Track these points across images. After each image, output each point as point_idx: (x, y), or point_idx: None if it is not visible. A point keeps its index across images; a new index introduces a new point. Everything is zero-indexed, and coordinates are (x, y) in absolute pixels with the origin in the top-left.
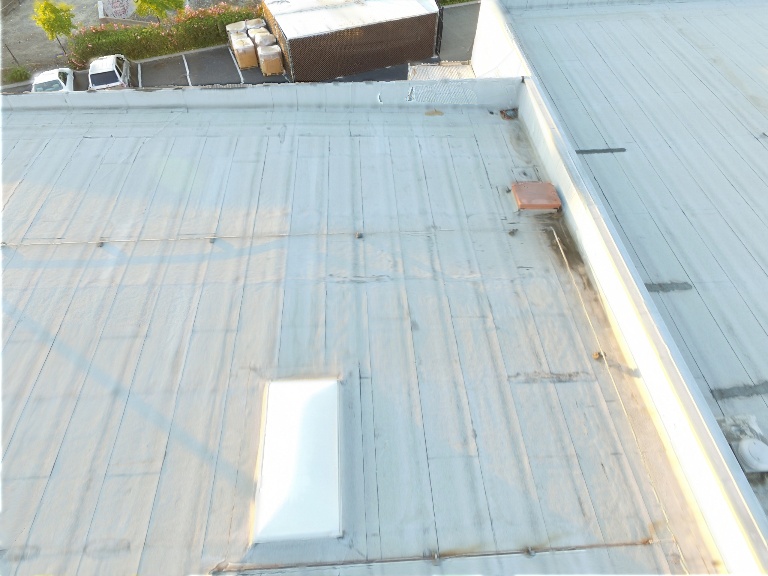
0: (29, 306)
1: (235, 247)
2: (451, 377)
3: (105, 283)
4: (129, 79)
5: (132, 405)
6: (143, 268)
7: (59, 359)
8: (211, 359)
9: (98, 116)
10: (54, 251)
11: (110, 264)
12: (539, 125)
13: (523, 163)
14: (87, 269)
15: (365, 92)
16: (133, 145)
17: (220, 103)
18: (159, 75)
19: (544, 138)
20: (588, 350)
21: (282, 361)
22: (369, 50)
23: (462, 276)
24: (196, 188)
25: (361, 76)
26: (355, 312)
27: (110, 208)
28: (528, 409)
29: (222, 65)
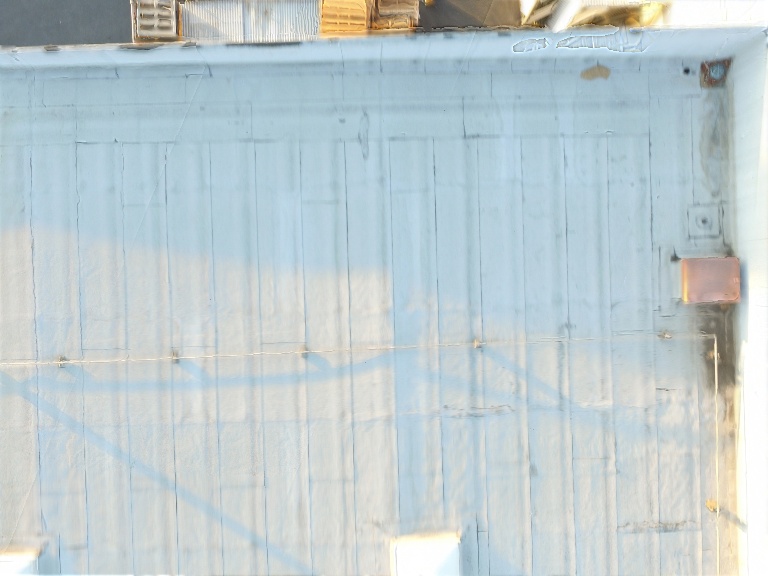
0: (133, 449)
1: (333, 366)
2: (563, 529)
3: (201, 419)
4: None
5: (273, 559)
6: (236, 398)
7: (189, 511)
8: (334, 514)
9: (77, 87)
10: (126, 370)
11: (197, 391)
12: (759, 145)
13: (707, 195)
14: (174, 399)
15: (493, 44)
16: (153, 163)
17: (258, 58)
18: None
19: (757, 174)
20: (703, 497)
21: (403, 517)
22: None
23: (591, 404)
24: (264, 258)
25: None
26: (473, 457)
27: (165, 296)
28: (629, 560)
29: None
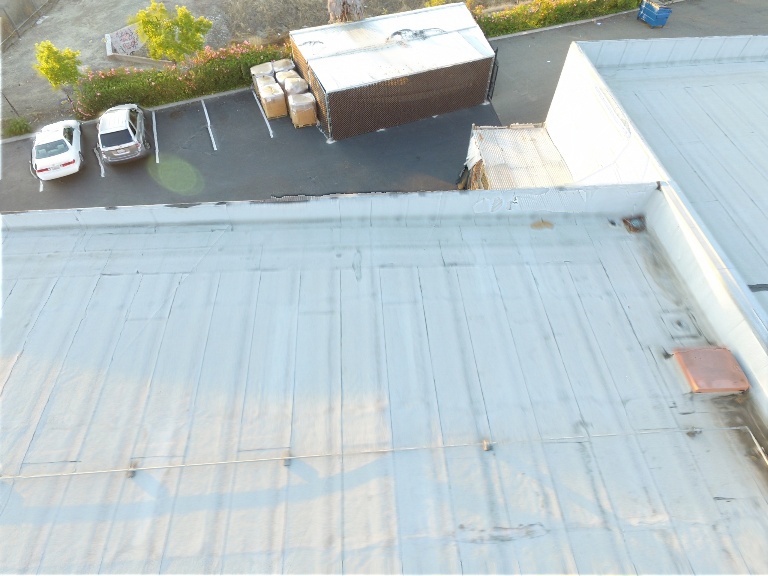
0: None
1: (320, 475)
2: None
3: (141, 554)
4: (144, 135)
5: None
6: (194, 521)
7: None
8: None
9: (119, 239)
10: (66, 487)
11: (147, 513)
12: (694, 256)
13: (672, 305)
14: (114, 524)
15: (457, 203)
16: (166, 287)
17: (273, 217)
18: (176, 126)
19: (704, 277)
20: None
21: None
22: (416, 99)
23: (643, 520)
24: (255, 362)
25: (406, 128)
26: None
27: (141, 401)
28: None
29: (247, 113)
